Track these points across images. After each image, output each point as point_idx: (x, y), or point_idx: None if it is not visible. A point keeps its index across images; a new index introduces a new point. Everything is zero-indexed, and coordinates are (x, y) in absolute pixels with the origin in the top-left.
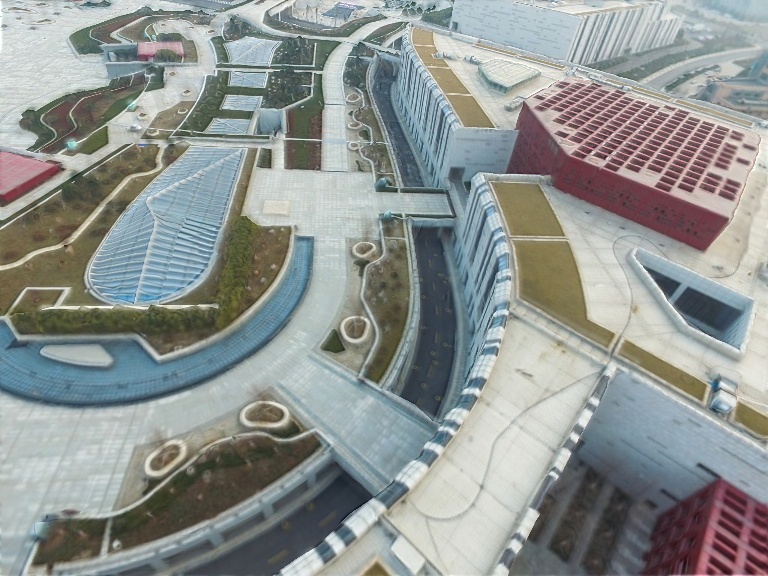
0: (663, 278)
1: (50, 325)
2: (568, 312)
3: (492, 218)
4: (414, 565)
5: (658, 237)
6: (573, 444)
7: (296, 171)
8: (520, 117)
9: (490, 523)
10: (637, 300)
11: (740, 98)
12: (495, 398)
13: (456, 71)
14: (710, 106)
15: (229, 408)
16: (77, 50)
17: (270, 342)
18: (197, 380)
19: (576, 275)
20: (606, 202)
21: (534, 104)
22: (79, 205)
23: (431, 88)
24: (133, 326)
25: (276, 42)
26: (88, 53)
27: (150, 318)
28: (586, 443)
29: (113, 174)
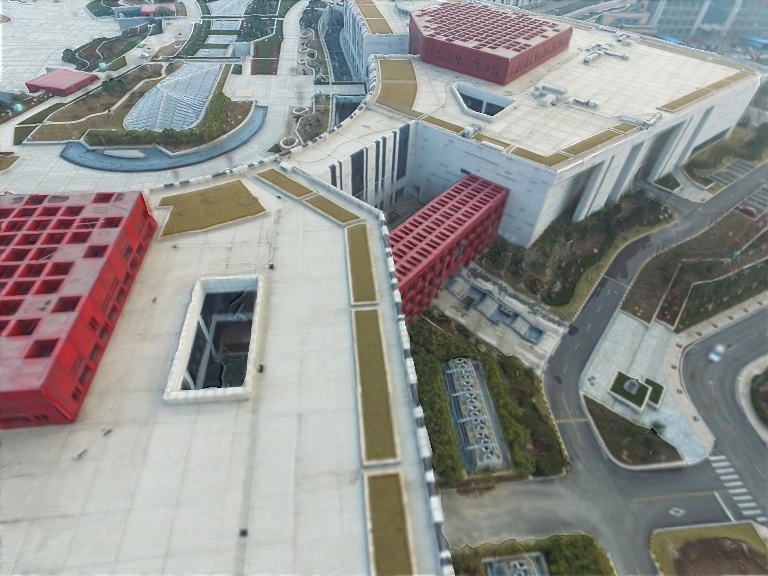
0: (474, 100)
1: (108, 137)
2: (401, 107)
3: (372, 73)
4: (288, 166)
5: (478, 81)
6: (378, 142)
7: (259, 75)
8: (409, 25)
9: (329, 163)
10: (447, 104)
11: (620, 23)
12: (346, 133)
13: (379, 6)
14: (566, 19)
15: (213, 172)
16: (94, 14)
17: (237, 149)
18: (194, 162)
19: (414, 94)
20: (450, 65)
21: (416, 14)
22: (113, 94)
23: (356, 16)
24: (155, 139)
25: (248, 0)
26: (102, 15)
27: (165, 133)
28: (420, 187)
29: (133, 79)
